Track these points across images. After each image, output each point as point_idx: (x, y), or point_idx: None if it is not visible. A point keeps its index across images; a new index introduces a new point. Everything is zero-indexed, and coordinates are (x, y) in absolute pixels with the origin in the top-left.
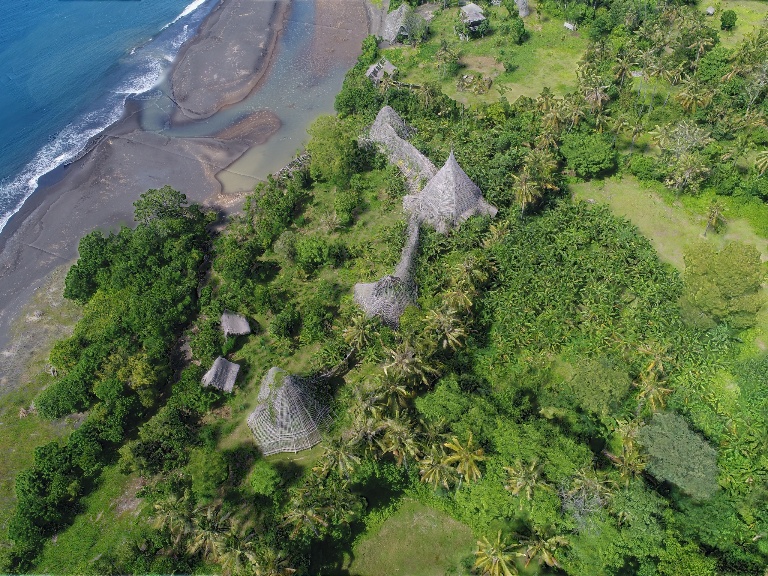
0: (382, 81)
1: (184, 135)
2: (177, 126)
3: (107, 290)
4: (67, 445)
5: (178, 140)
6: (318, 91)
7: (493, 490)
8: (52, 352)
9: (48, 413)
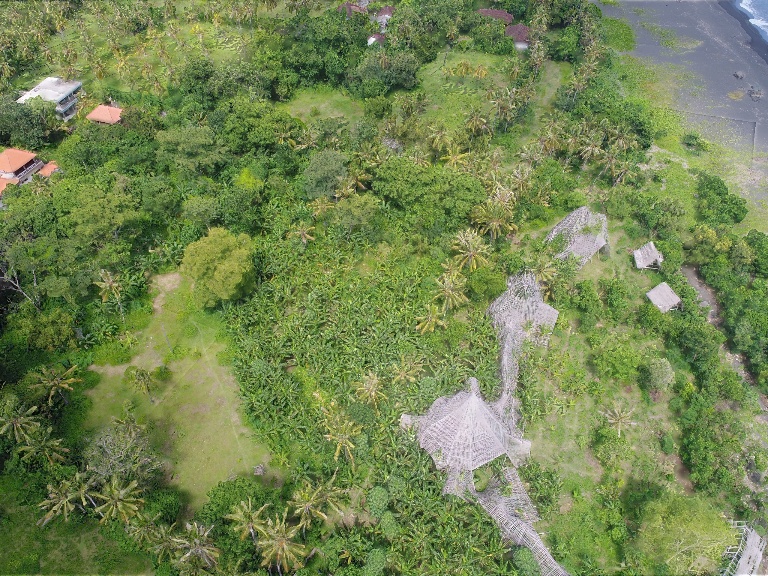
0: None
1: None
2: None
3: None
4: None
5: None
6: None
7: None
8: None
9: None
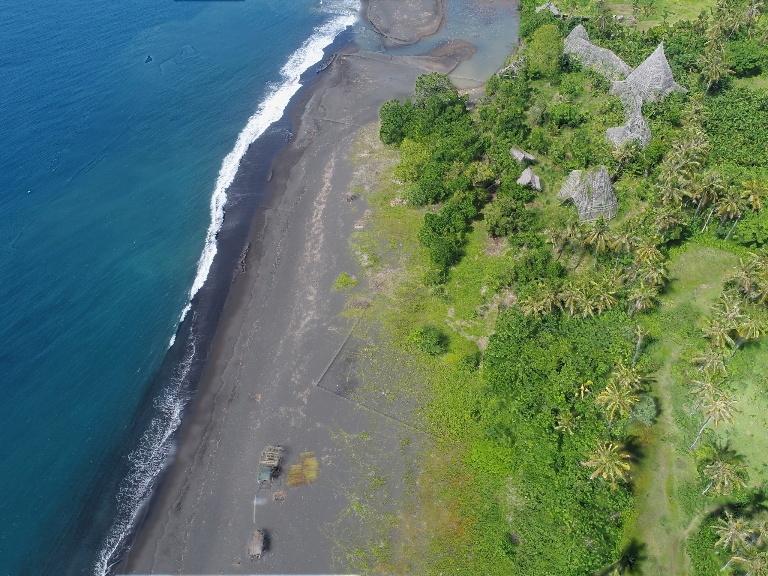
0: (557, 15)
1: (400, 54)
2: (391, 49)
3: (413, 138)
4: (443, 215)
5: (399, 57)
6: (494, 27)
7: (767, 218)
8: (396, 170)
9: (416, 201)
